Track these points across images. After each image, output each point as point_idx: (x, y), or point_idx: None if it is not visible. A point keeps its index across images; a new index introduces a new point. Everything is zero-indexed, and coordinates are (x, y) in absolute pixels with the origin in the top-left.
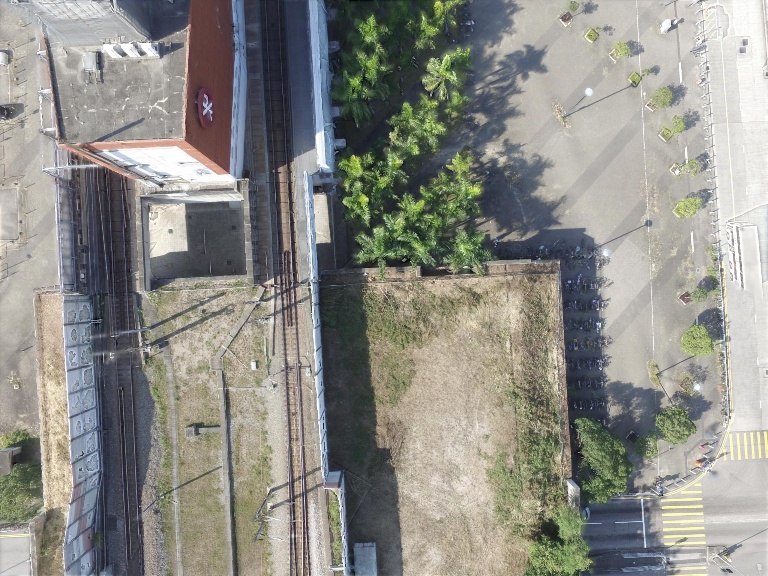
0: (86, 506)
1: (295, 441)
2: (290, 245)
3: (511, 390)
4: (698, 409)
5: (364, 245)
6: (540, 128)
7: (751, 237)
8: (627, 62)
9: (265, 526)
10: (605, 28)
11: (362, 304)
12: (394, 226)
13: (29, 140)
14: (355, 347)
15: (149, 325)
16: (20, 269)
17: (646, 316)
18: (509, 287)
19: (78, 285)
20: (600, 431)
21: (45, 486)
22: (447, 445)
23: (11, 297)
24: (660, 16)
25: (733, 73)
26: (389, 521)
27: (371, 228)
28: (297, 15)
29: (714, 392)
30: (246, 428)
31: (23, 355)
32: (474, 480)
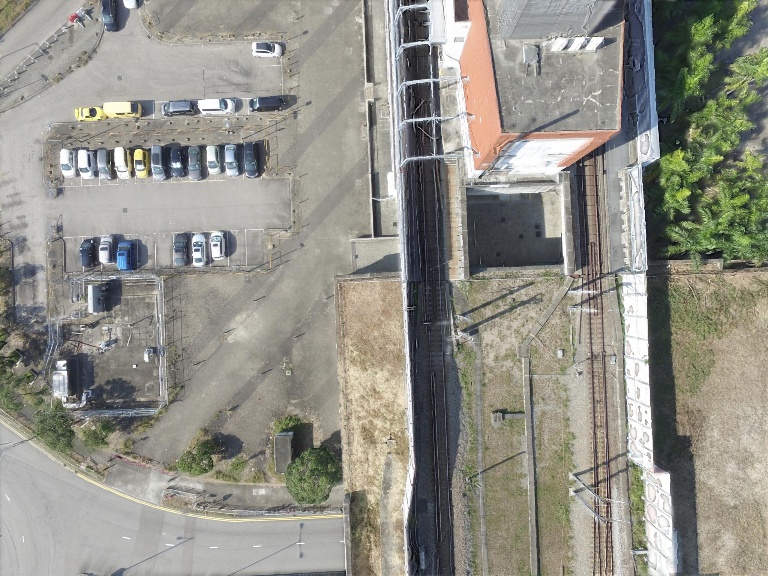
0: (395, 489)
1: (599, 428)
2: (597, 237)
3: None
4: None
5: (678, 238)
6: None
7: None
8: None
9: (567, 510)
10: None
11: (668, 295)
12: (720, 219)
13: (302, 131)
14: (658, 337)
15: (459, 313)
16: (293, 257)
17: None
18: None
19: None
20: None
21: (345, 469)
22: (743, 433)
23: (284, 285)
24: None
25: None
26: (686, 506)
27: (677, 221)
28: None
29: None
30: (548, 414)
31: (296, 342)
32: (767, 468)
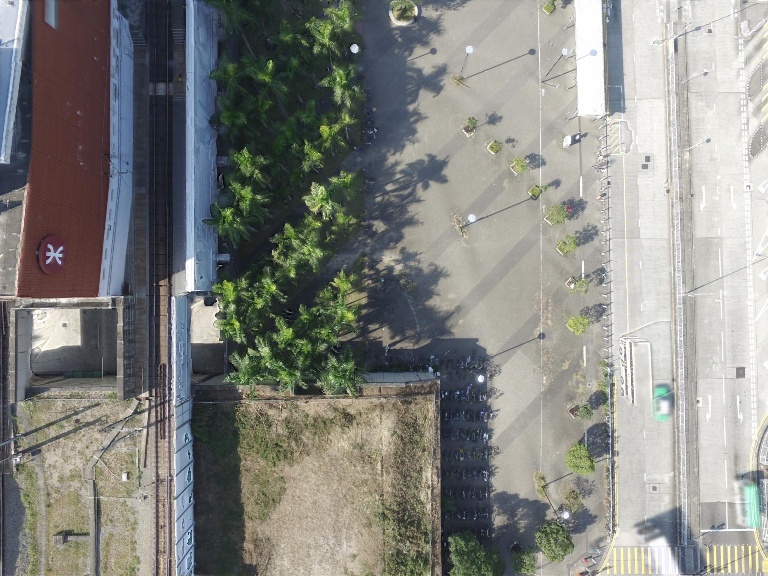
0: None
1: (162, 553)
2: (166, 359)
3: (380, 511)
4: (583, 522)
5: (236, 366)
6: (438, 237)
7: (644, 353)
8: (528, 175)
9: None
10: (508, 140)
11: (234, 421)
12: (261, 353)
13: None
14: (226, 462)
15: (23, 432)
16: None
17: (535, 428)
18: (382, 409)
19: None
20: (471, 552)
21: None
22: (314, 563)
23: None
24: (563, 130)
25: (634, 189)
26: None
27: (247, 346)
28: (183, 133)
29: (600, 506)
30: (116, 537)
31: None
32: None
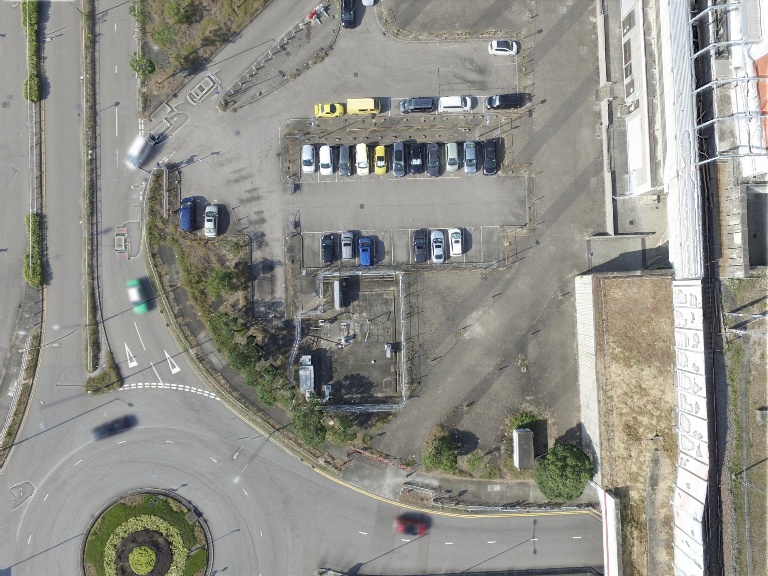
0: (663, 485)
1: None
2: None
3: None
4: None
5: None
6: None
7: None
8: None
9: None
10: None
11: None
12: None
13: (537, 129)
14: None
15: (728, 311)
16: (529, 255)
17: None
18: None
19: None
20: None
21: (604, 465)
22: None
23: (520, 282)
24: None
25: None
26: None
27: None
28: None
29: None
30: None
31: (531, 339)
32: None
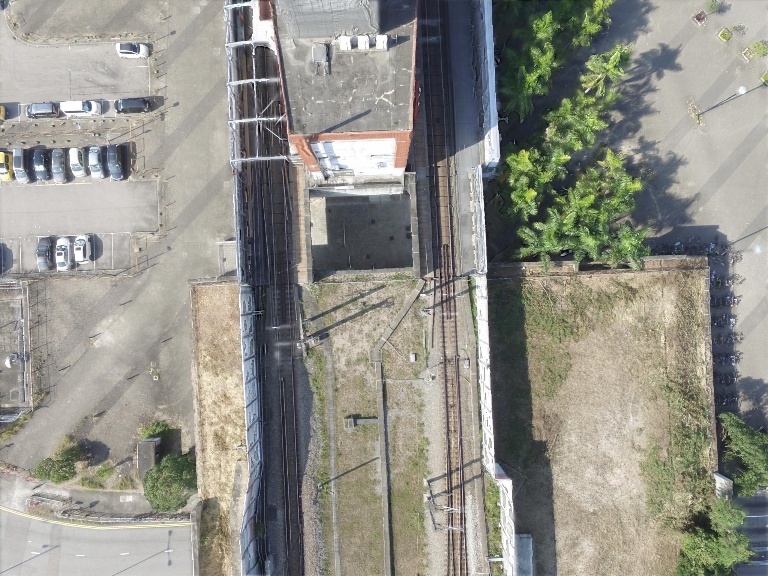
0: None
1: (453, 433)
2: (450, 239)
3: (665, 384)
4: None
5: (528, 239)
6: (675, 126)
7: None
8: (760, 61)
9: (422, 517)
10: None
11: (521, 298)
12: (564, 220)
13: (169, 133)
14: (513, 340)
15: (309, 317)
16: (160, 261)
17: None
18: (664, 282)
19: (247, 276)
20: None
21: (199, 476)
22: (601, 438)
23: (151, 289)
24: None
25: None
26: (544, 513)
27: (531, 222)
28: (460, 11)
29: None
30: (402, 420)
31: (163, 346)
32: (627, 473)
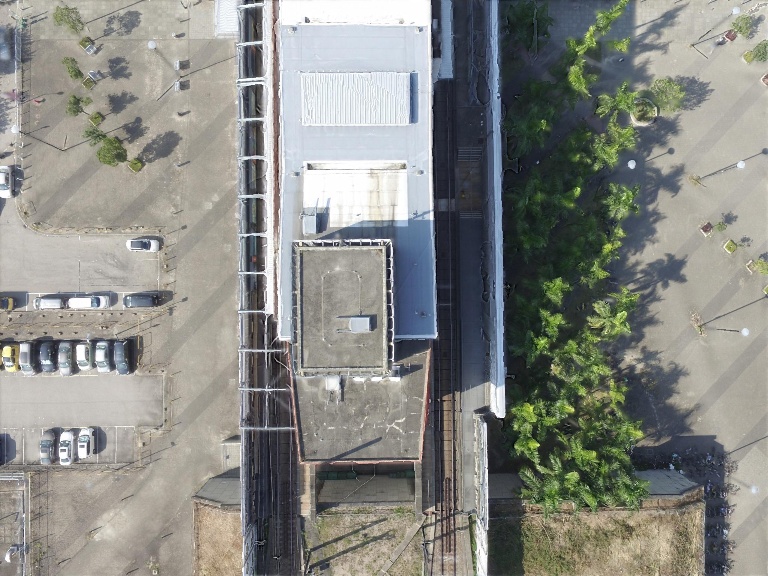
0: None
1: None
2: (452, 473)
3: None
4: None
5: (529, 483)
6: (677, 336)
7: None
8: None
9: None
10: (743, 239)
11: (520, 535)
12: (566, 476)
13: (177, 328)
14: (510, 575)
15: (311, 547)
16: (163, 456)
17: None
18: (661, 521)
19: (251, 516)
20: None
21: None
22: None
23: (153, 484)
24: None
25: None
26: None
27: (532, 461)
28: (471, 252)
29: None
30: None
31: (163, 541)
32: None
